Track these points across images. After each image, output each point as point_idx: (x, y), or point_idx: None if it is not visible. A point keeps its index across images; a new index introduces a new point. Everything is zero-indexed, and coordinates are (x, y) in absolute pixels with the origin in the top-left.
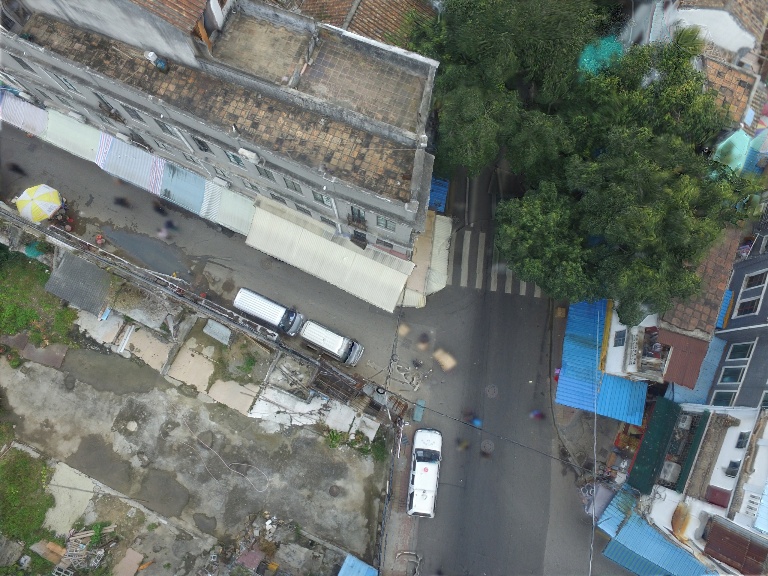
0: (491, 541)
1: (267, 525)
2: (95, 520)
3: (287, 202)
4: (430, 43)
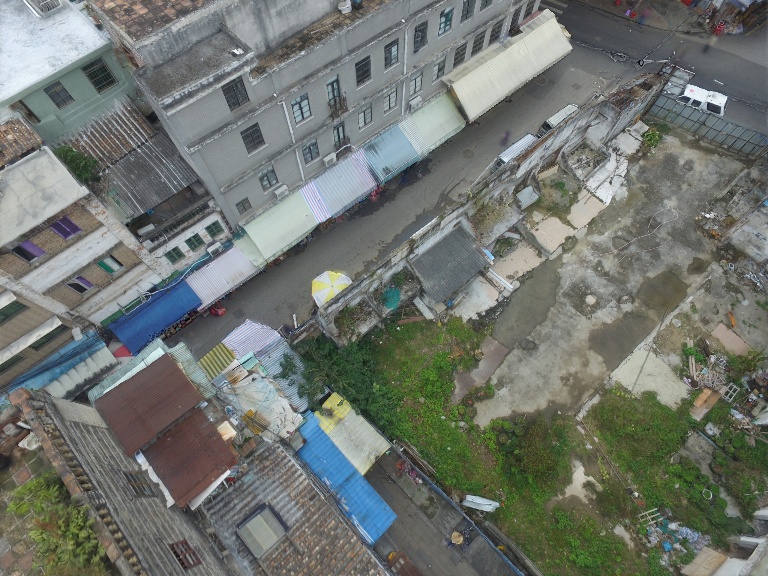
0: (745, 88)
1: (710, 217)
2: (678, 356)
3: (467, 52)
4: None
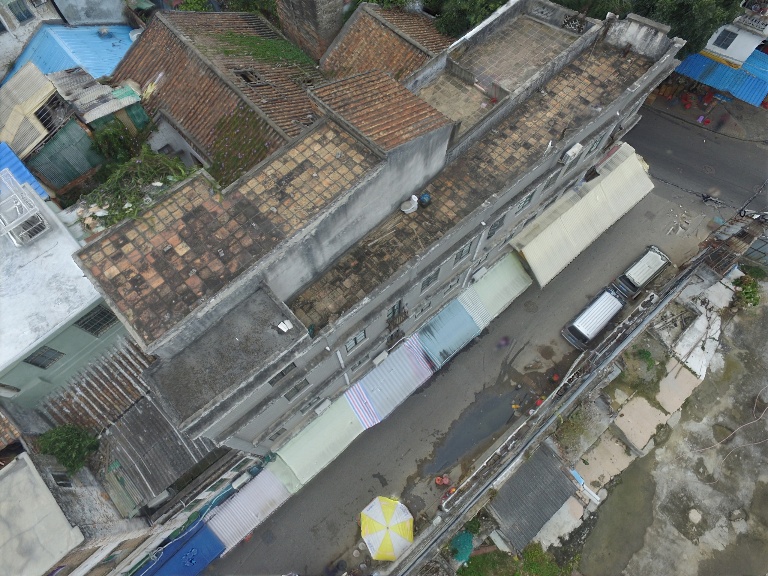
0: None
1: None
2: None
3: (539, 211)
4: (479, 6)
